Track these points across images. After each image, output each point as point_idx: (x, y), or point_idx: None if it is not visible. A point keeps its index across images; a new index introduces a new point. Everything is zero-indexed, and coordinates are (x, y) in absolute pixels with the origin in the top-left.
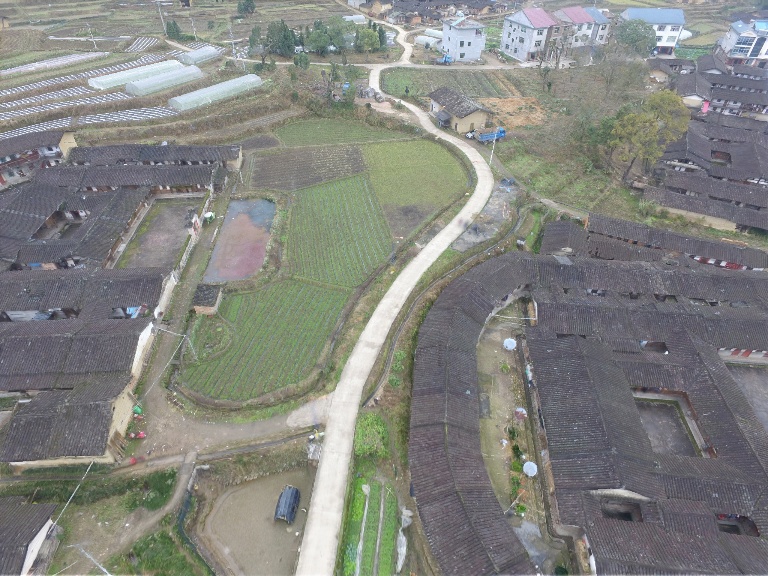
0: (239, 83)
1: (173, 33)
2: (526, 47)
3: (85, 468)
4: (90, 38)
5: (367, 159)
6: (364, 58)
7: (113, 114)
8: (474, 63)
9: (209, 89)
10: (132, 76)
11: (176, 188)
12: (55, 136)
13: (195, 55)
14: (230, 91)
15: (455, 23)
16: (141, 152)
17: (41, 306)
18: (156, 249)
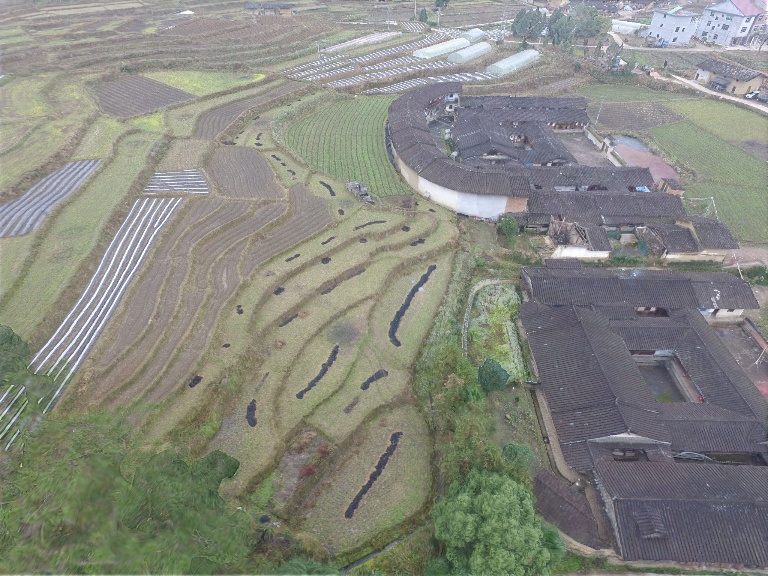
0: (528, 56)
1: (425, 19)
2: (731, 33)
3: (707, 263)
4: (364, 22)
5: (677, 111)
6: (589, 41)
7: (451, 76)
8: (686, 46)
9: (513, 59)
10: (443, 49)
11: (559, 125)
12: (457, 86)
13: (473, 35)
14: (525, 62)
15: (672, 11)
16: (512, 101)
17: (579, 183)
18: (587, 162)
